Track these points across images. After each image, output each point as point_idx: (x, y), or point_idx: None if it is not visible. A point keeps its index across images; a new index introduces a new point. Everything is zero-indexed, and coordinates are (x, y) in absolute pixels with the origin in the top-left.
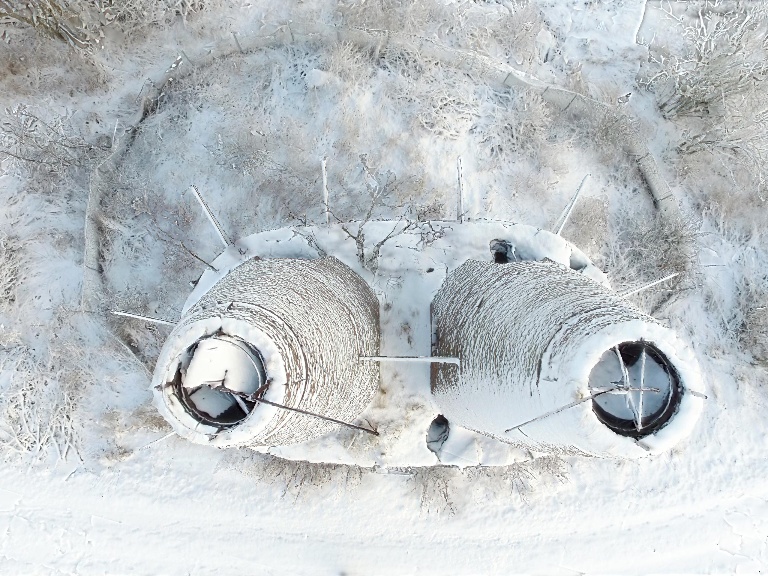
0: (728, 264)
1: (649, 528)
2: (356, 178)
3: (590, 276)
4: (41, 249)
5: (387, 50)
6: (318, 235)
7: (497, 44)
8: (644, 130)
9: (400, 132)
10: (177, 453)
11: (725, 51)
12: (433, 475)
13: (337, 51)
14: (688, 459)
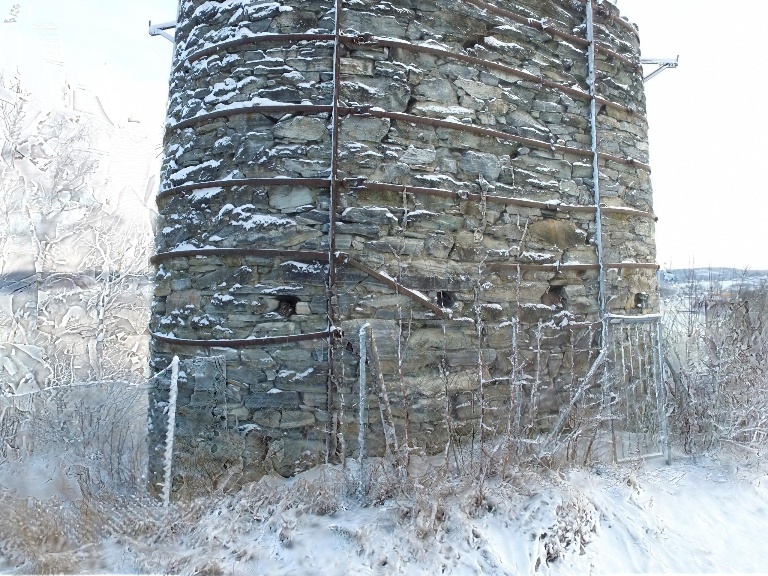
0: None
1: None
2: None
3: None
4: None
5: None
6: None
7: None
8: None
9: None
10: None
11: None
12: (729, 454)
13: None
14: None
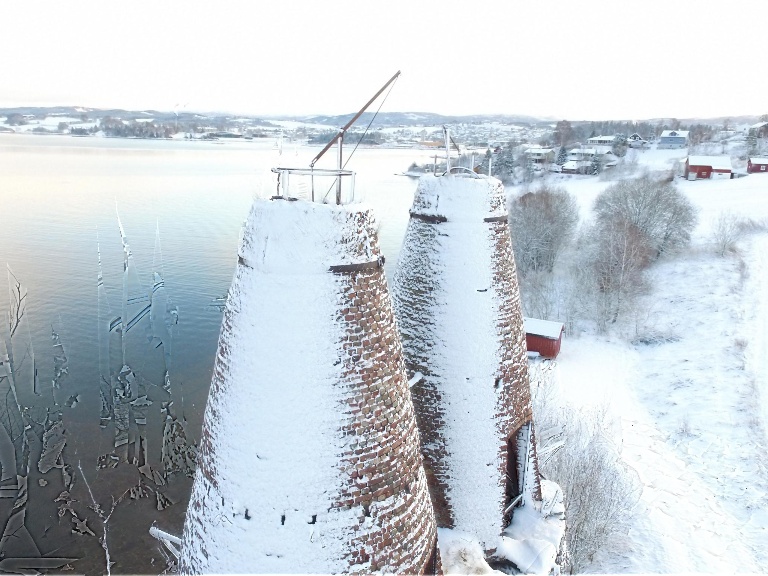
0: None
1: None
2: None
3: None
4: None
5: None
6: None
7: None
8: None
9: None
10: None
11: None
12: None
13: None
14: None
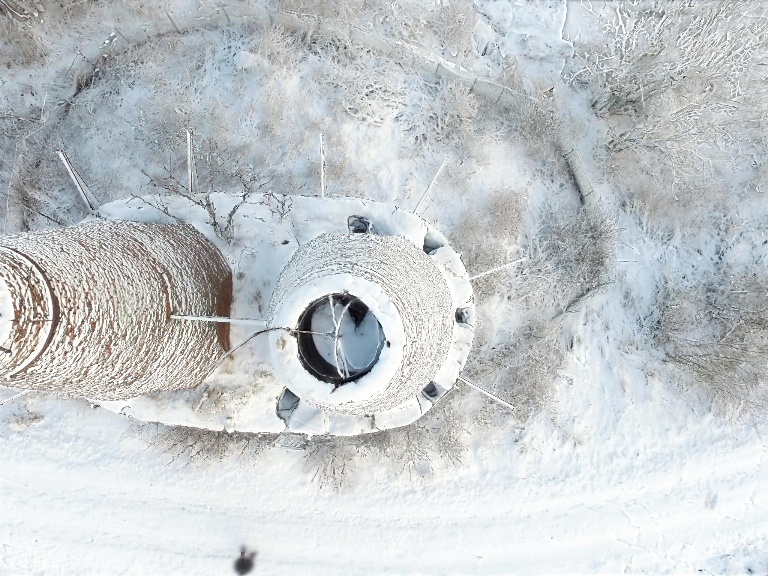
0: (650, 262)
1: (548, 516)
2: (278, 160)
3: (443, 255)
4: None
5: (319, 36)
6: (179, 204)
7: (433, 35)
8: (576, 127)
9: (323, 116)
10: (87, 421)
11: (645, 50)
12: None
13: (266, 34)
14: (591, 450)
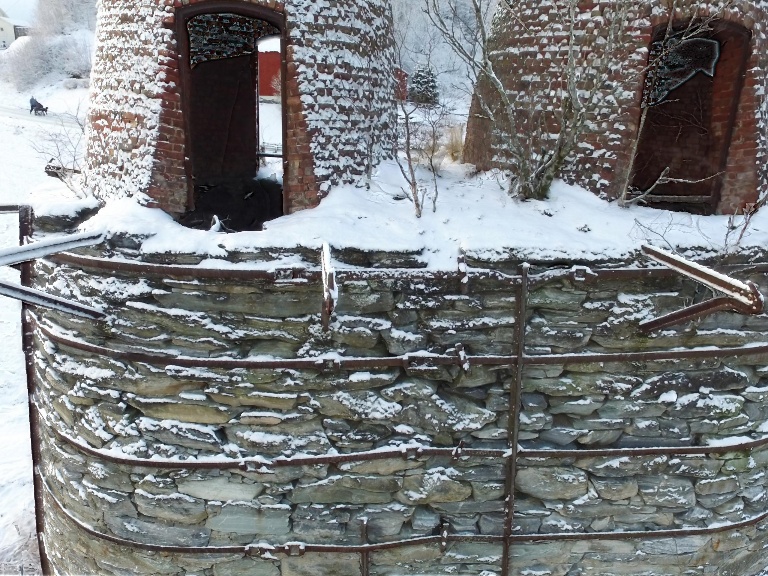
0: None
1: None
2: None
3: (68, 202)
4: None
5: None
6: None
7: None
8: None
9: None
10: None
11: None
12: None
13: None
14: None
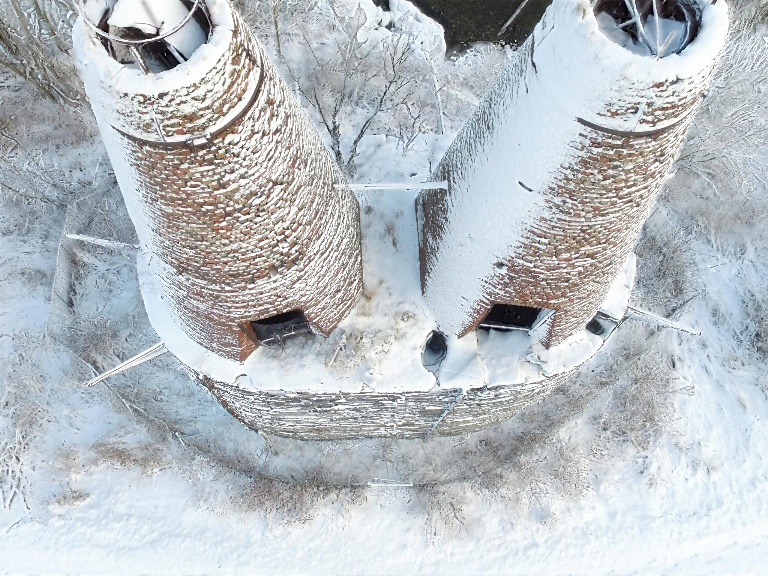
0: (728, 279)
1: (699, 562)
2: None
3: None
4: (10, 290)
5: (365, 93)
6: None
7: (469, 91)
8: None
9: None
10: (140, 495)
11: None
12: None
13: (316, 90)
14: (728, 477)
